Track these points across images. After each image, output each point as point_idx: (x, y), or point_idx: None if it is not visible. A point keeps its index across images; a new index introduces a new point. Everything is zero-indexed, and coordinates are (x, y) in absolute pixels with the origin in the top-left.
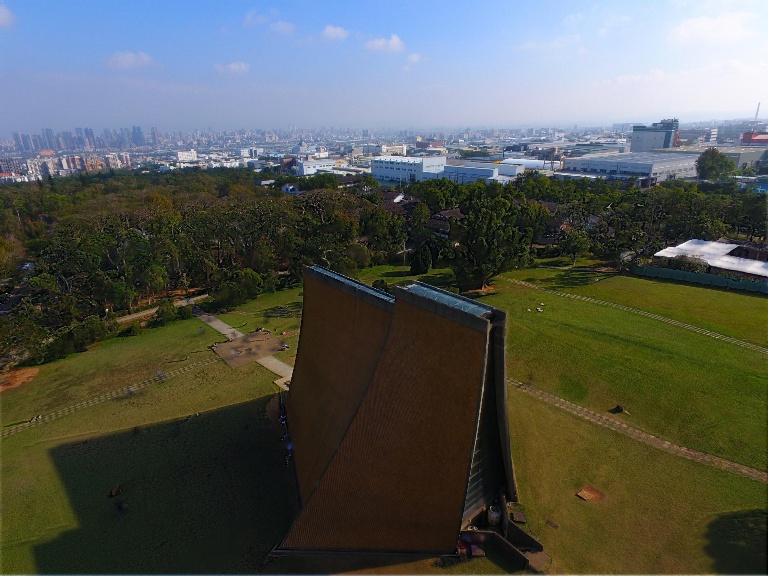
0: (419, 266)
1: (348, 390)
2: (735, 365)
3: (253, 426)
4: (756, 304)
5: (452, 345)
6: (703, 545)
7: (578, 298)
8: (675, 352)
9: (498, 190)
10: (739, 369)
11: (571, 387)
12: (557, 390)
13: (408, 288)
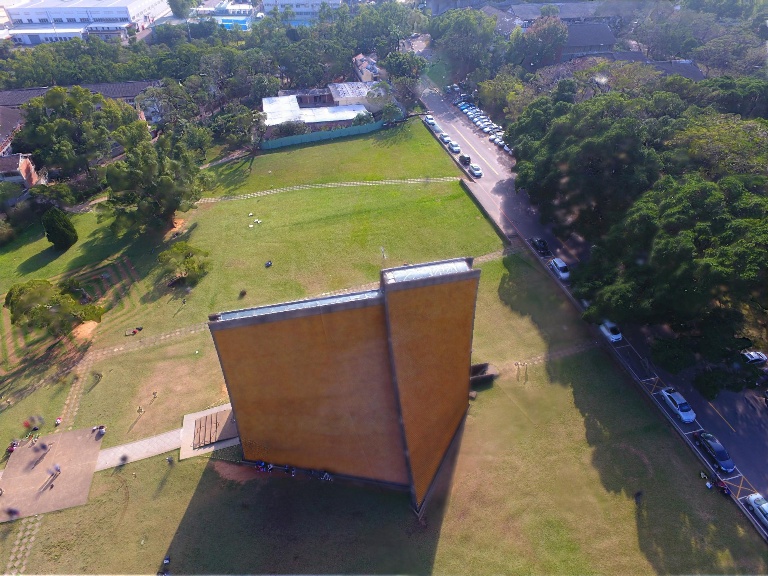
0: (66, 236)
1: (354, 386)
2: (408, 200)
3: (249, 499)
4: (360, 147)
5: (451, 297)
6: (512, 306)
7: (264, 194)
8: (377, 208)
9: (64, 98)
10: (413, 202)
11: (370, 270)
12: (368, 278)
13: (394, 279)
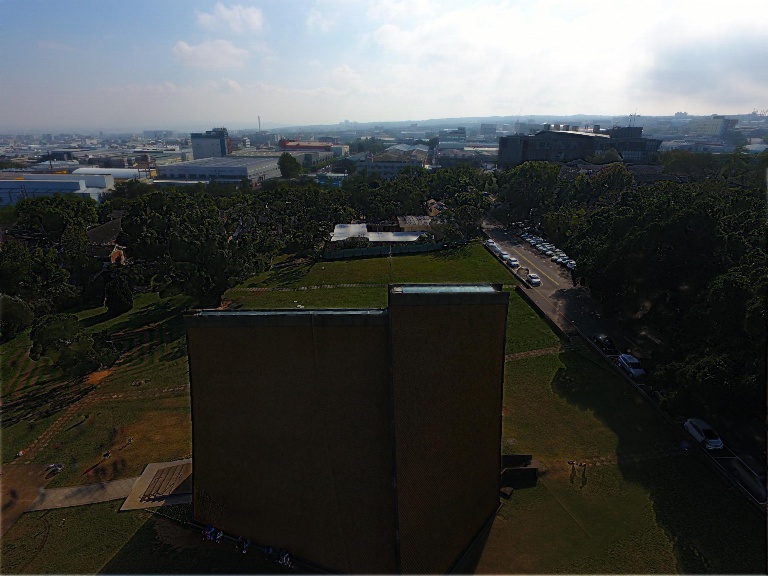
0: (122, 303)
1: (342, 430)
2: None
3: (178, 572)
4: (417, 260)
5: (472, 326)
6: (569, 400)
7: (314, 288)
8: None
9: (164, 201)
10: None
11: None
12: None
13: (401, 291)
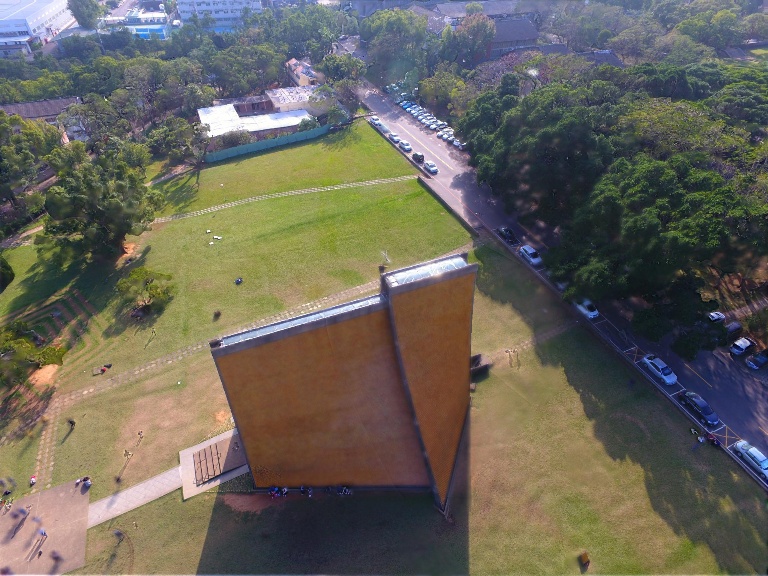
0: (2, 275)
1: (364, 394)
2: (370, 202)
3: (268, 528)
4: (310, 152)
5: (451, 294)
6: (492, 295)
7: (219, 209)
8: (340, 213)
9: None
10: (375, 203)
11: (346, 276)
12: (346, 284)
13: (397, 282)
